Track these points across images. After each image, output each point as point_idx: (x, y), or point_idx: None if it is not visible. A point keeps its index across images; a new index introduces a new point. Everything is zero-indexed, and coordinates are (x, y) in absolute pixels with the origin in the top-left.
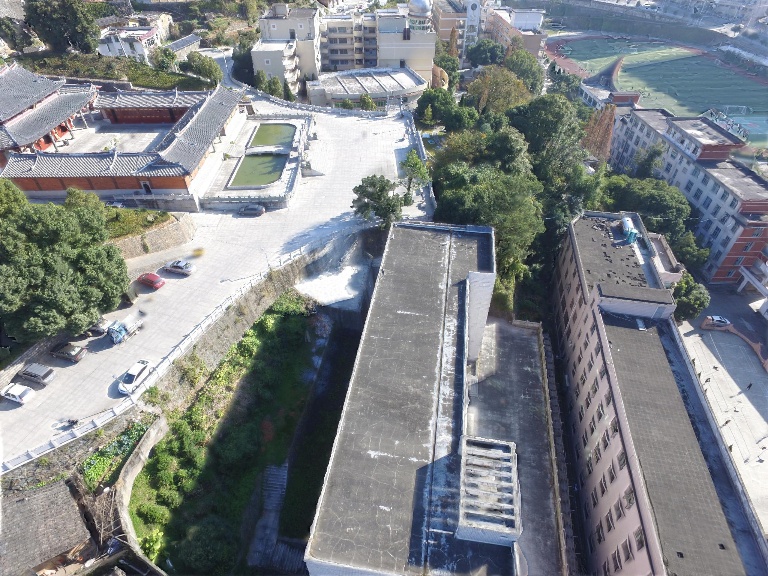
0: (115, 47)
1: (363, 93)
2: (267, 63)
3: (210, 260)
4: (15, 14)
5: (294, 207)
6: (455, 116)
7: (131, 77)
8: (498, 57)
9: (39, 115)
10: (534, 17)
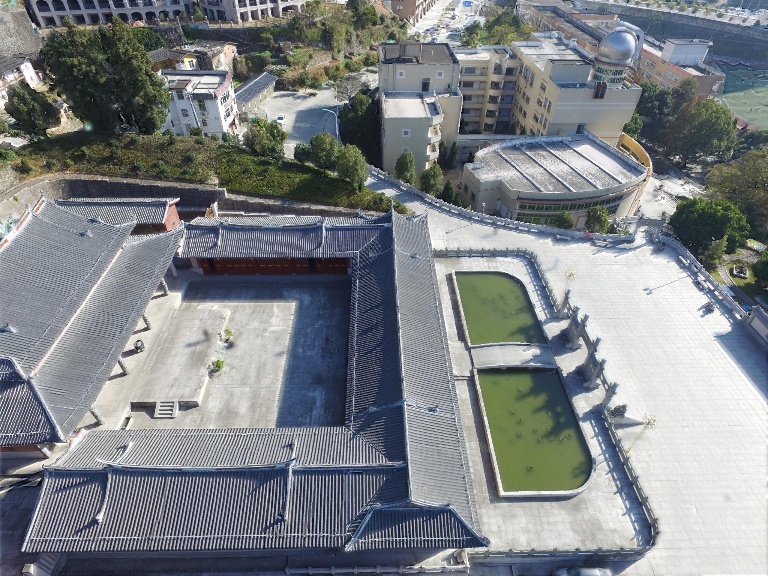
0: (177, 106)
1: (568, 192)
2: (405, 134)
3: None
4: (24, 45)
5: (657, 555)
6: None
7: (224, 177)
8: (666, 106)
9: (94, 314)
10: (697, 50)
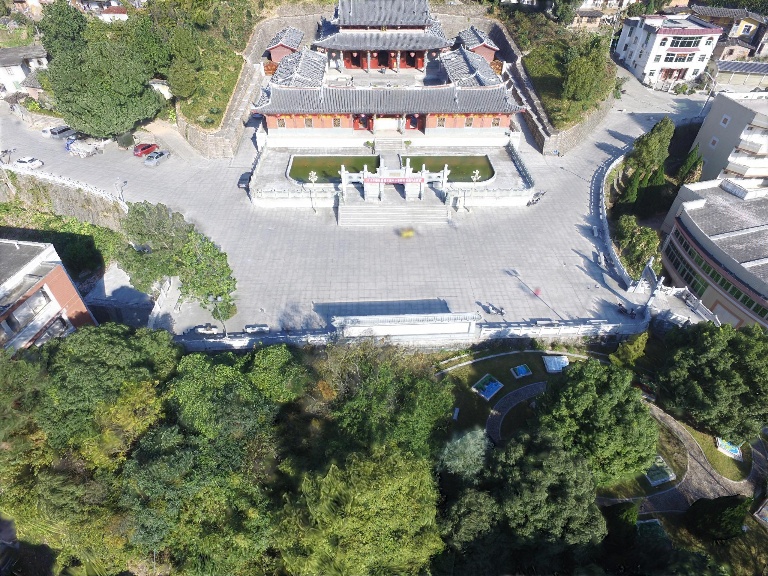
0: (636, 33)
1: None
2: (724, 122)
3: (166, 172)
4: None
5: (251, 208)
6: (566, 379)
7: None
8: None
9: (378, 37)
10: None
